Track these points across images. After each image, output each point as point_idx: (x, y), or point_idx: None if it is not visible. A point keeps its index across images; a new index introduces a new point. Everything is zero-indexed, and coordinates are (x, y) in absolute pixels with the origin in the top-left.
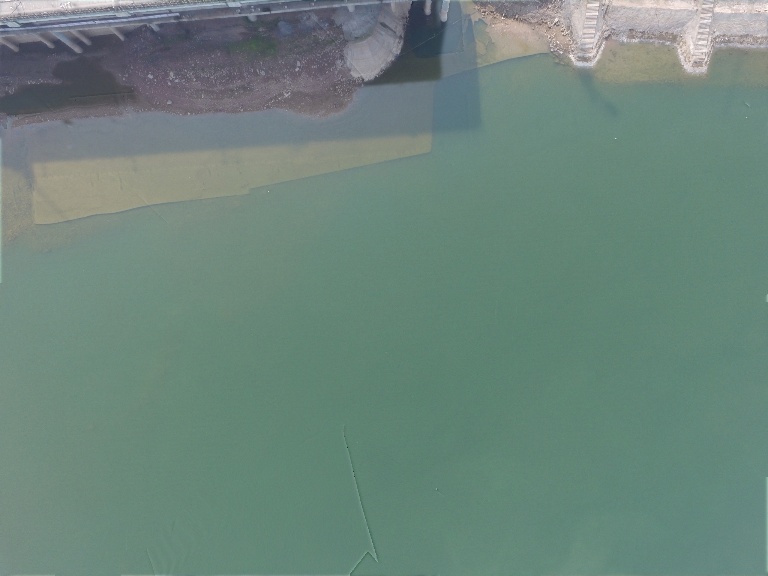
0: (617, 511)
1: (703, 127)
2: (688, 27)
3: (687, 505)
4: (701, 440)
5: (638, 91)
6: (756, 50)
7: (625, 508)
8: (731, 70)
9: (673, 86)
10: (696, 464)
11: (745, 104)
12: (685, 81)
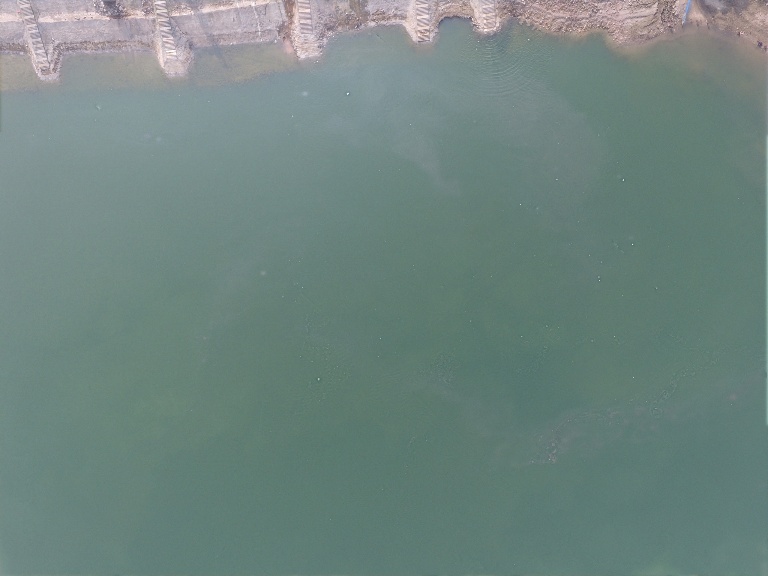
0: (2, 497)
1: (59, 131)
2: (27, 37)
3: (68, 489)
4: (82, 428)
5: None
6: (104, 55)
7: (9, 494)
8: (85, 75)
9: (34, 94)
10: (75, 451)
11: (96, 107)
12: (43, 88)
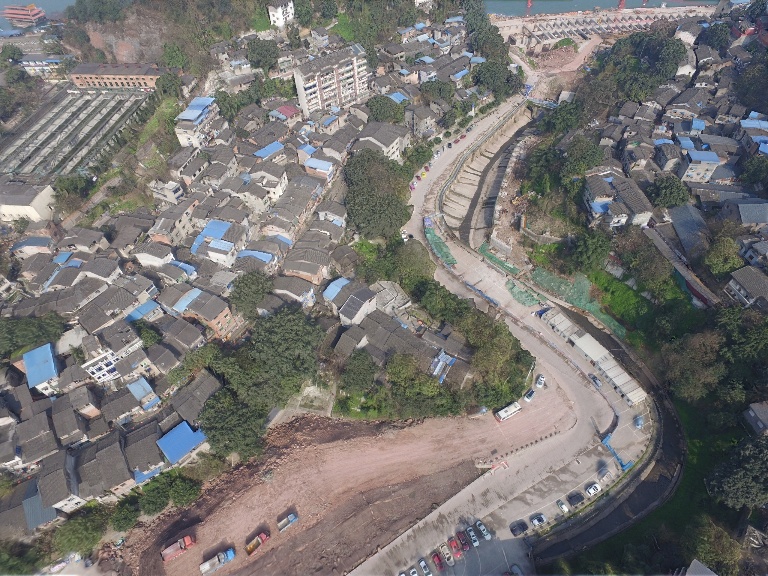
0: None
1: None
2: None
3: None
4: None
5: (696, 5)
6: None
7: None
8: None
9: None
10: None
11: (656, 5)
12: None
